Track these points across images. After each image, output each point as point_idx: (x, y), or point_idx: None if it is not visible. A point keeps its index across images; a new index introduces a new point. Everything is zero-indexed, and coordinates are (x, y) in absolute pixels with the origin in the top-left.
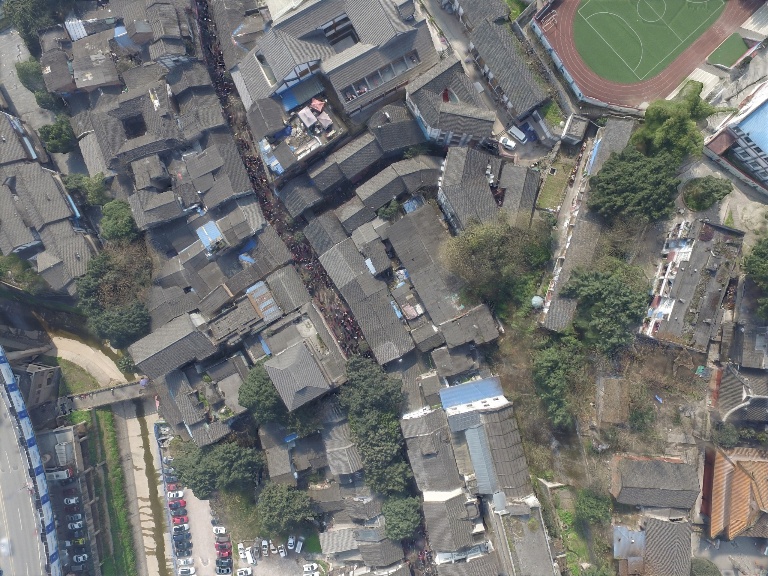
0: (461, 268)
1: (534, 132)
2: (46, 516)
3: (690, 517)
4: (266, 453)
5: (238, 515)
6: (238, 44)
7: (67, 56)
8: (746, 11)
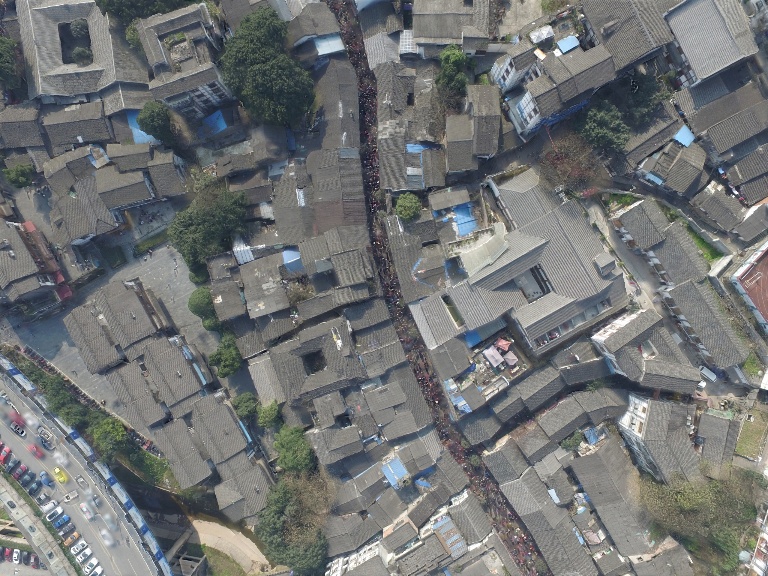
0: (667, 523)
1: (723, 370)
2: None
3: None
4: None
5: None
6: (418, 279)
7: (237, 285)
8: None
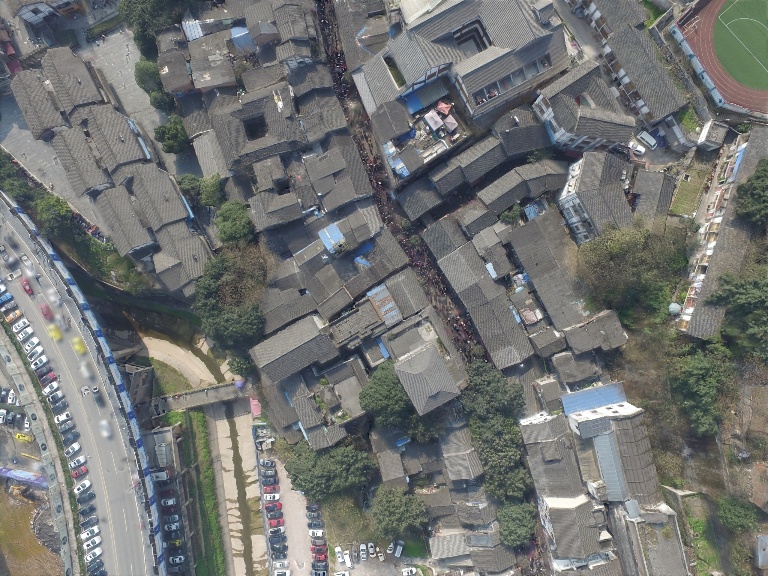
0: (597, 274)
1: (664, 138)
2: (154, 518)
3: None
4: (378, 457)
5: (352, 519)
6: (362, 46)
7: (184, 56)
8: None
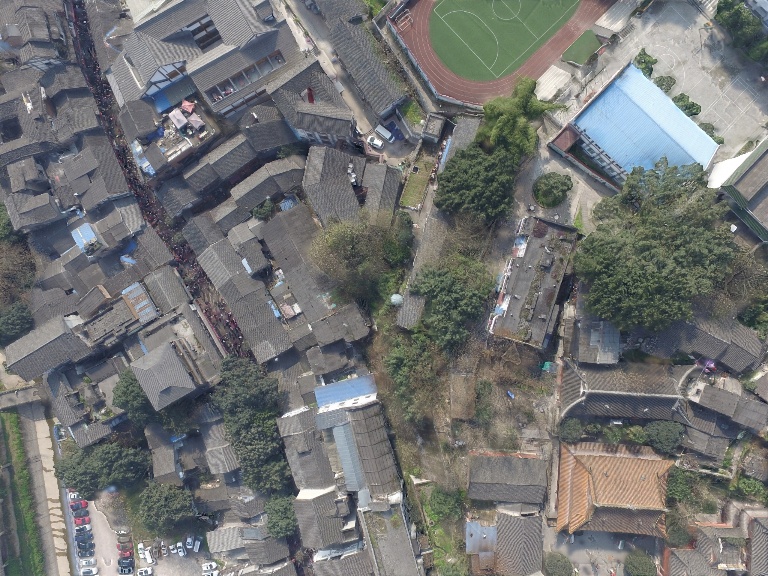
0: (321, 267)
1: (401, 131)
2: None
3: (546, 512)
4: (152, 453)
5: (121, 515)
6: (111, 46)
7: None
8: (600, 8)
